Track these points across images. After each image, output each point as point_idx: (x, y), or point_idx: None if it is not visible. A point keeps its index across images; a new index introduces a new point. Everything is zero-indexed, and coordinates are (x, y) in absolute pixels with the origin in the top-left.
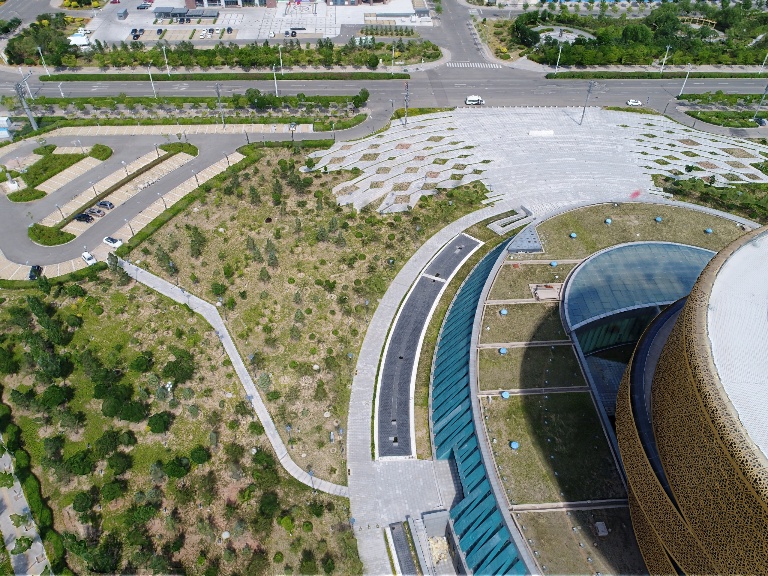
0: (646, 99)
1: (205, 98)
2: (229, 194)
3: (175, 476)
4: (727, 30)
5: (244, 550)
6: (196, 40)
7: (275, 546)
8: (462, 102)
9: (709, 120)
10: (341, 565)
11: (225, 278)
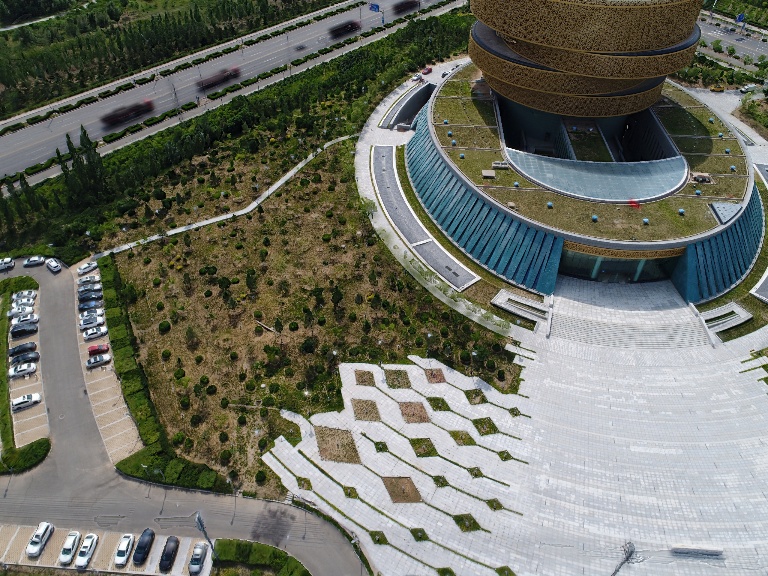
0: None
1: None
2: None
3: None
4: None
5: None
6: None
7: None
8: None
9: (307, 574)
10: None
11: None
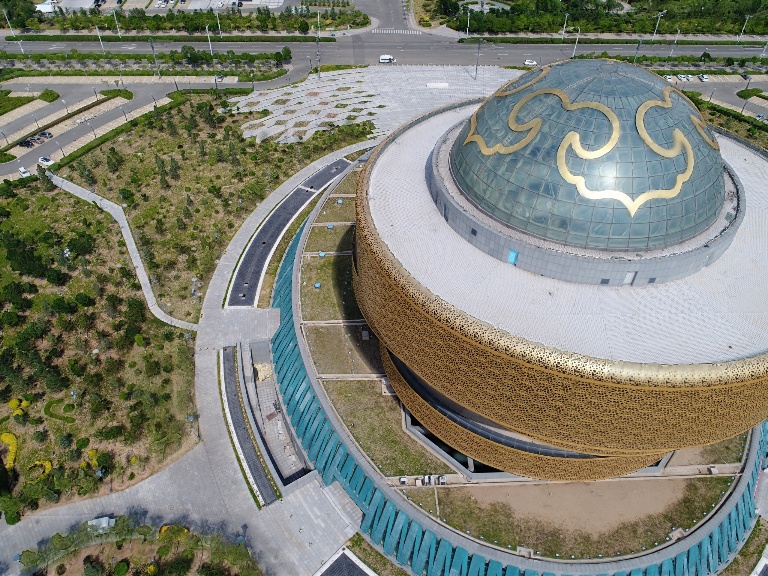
0: (543, 60)
1: None
2: (152, 128)
3: (60, 309)
4: (632, 3)
5: (106, 358)
6: (151, 9)
7: (132, 358)
8: (376, 61)
9: None
10: (179, 371)
11: (134, 187)
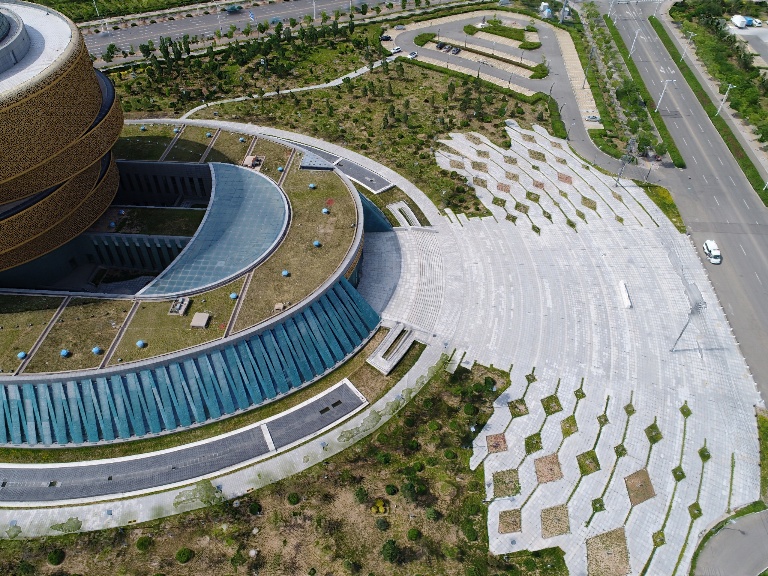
0: None
1: (638, 77)
2: None
3: None
4: None
5: None
6: None
7: (168, 99)
8: None
9: None
10: (147, 114)
11: None
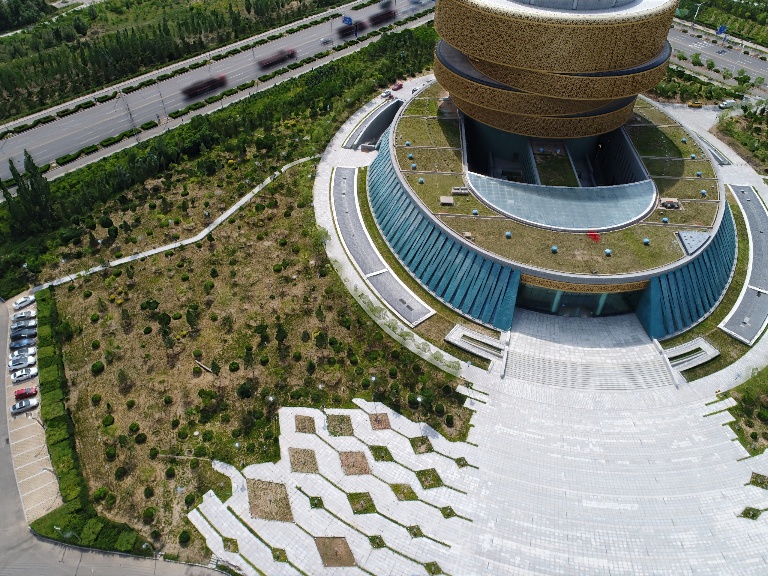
0: None
1: None
2: None
3: None
4: None
5: None
6: None
7: None
8: None
9: None
10: None
11: None
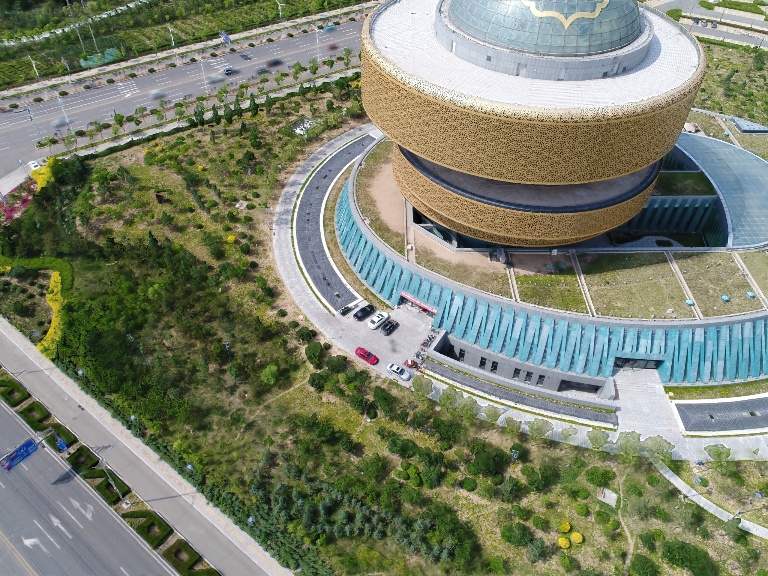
0: None
1: None
2: None
3: None
4: None
5: None
6: None
7: None
8: None
9: None
10: None
11: None
